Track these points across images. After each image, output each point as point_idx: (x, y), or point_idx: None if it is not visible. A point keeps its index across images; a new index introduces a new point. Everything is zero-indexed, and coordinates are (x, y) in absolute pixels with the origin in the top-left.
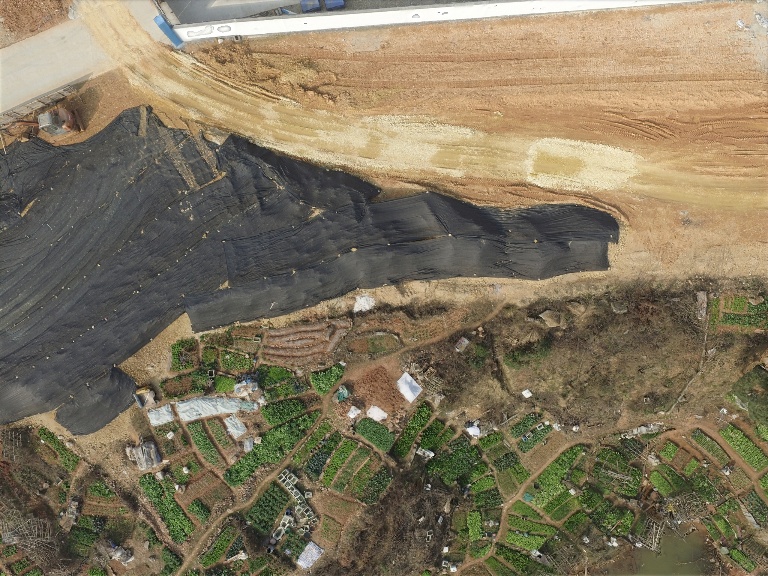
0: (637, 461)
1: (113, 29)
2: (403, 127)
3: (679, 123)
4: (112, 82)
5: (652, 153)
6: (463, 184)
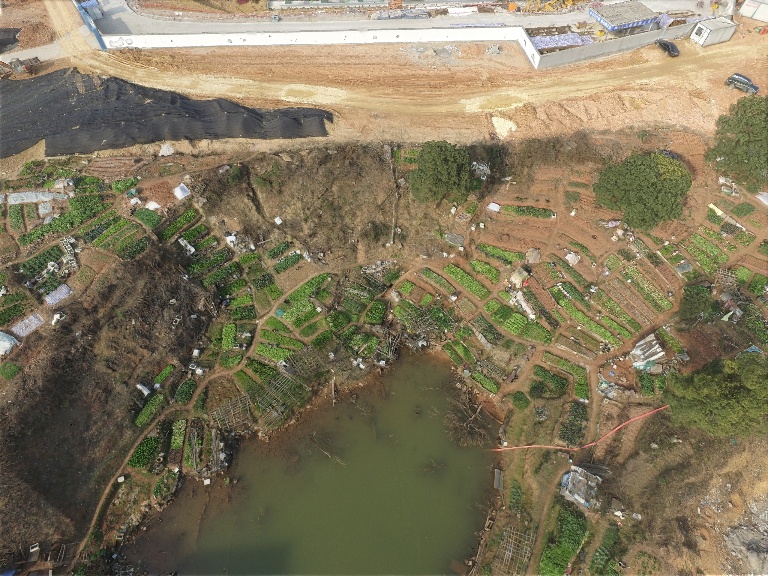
0: (382, 298)
1: (74, 45)
2: (214, 79)
3: (371, 80)
4: (61, 61)
5: (355, 90)
6: (243, 99)
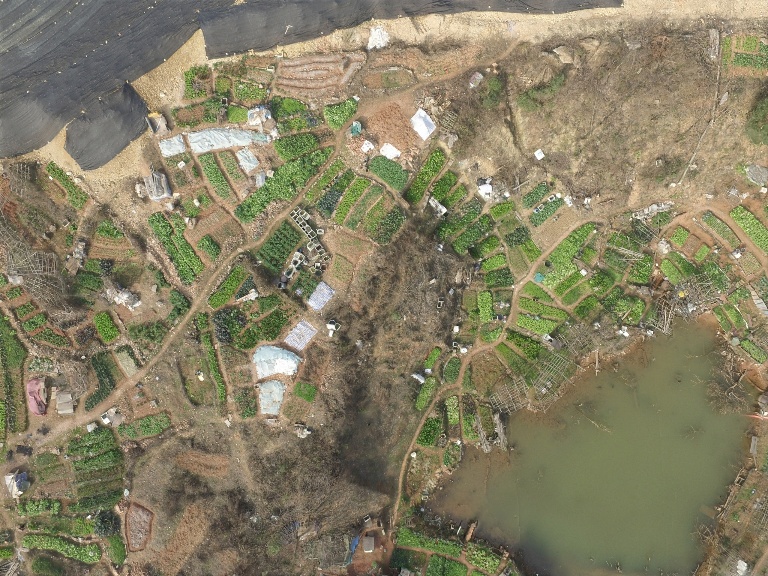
0: (648, 249)
1: None
2: None
3: None
4: None
5: None
6: None
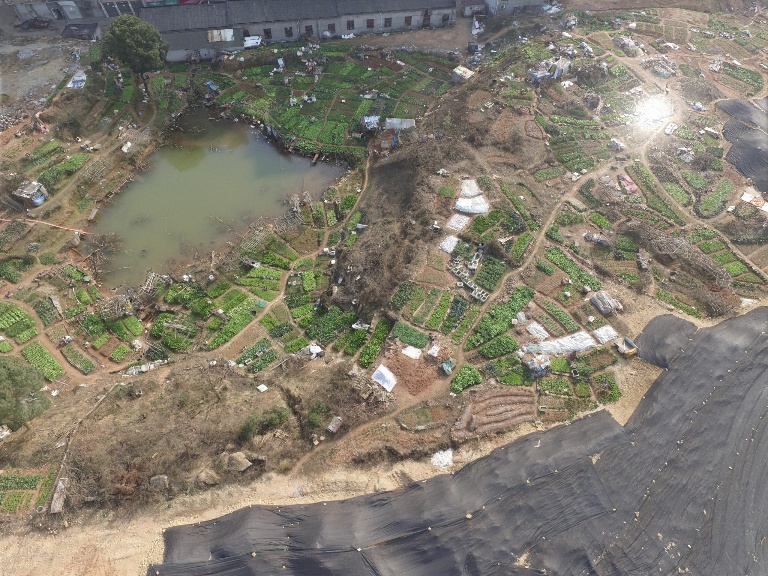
0: None
1: None
2: None
3: None
4: None
5: None
6: None
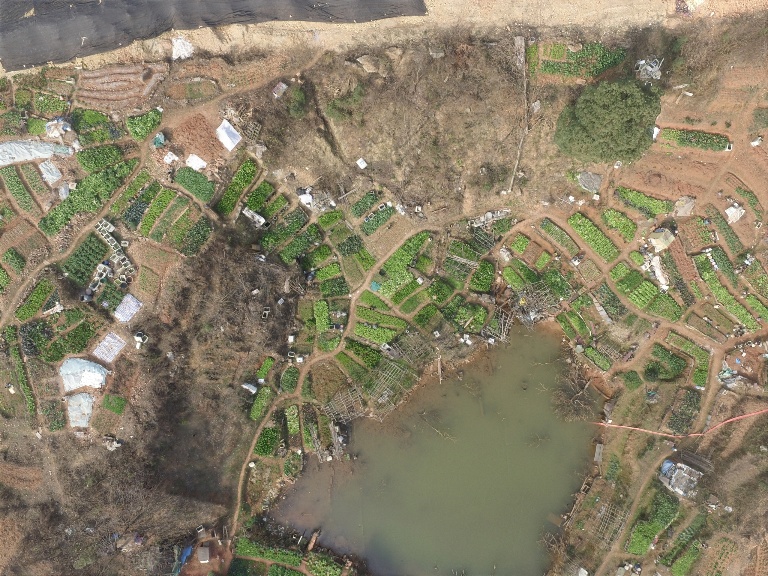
0: (490, 256)
1: None
2: None
3: None
4: None
5: None
6: None
